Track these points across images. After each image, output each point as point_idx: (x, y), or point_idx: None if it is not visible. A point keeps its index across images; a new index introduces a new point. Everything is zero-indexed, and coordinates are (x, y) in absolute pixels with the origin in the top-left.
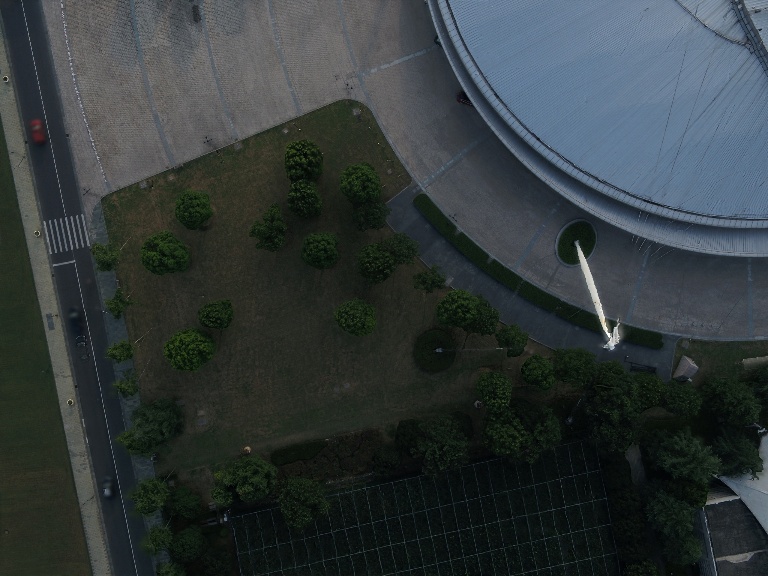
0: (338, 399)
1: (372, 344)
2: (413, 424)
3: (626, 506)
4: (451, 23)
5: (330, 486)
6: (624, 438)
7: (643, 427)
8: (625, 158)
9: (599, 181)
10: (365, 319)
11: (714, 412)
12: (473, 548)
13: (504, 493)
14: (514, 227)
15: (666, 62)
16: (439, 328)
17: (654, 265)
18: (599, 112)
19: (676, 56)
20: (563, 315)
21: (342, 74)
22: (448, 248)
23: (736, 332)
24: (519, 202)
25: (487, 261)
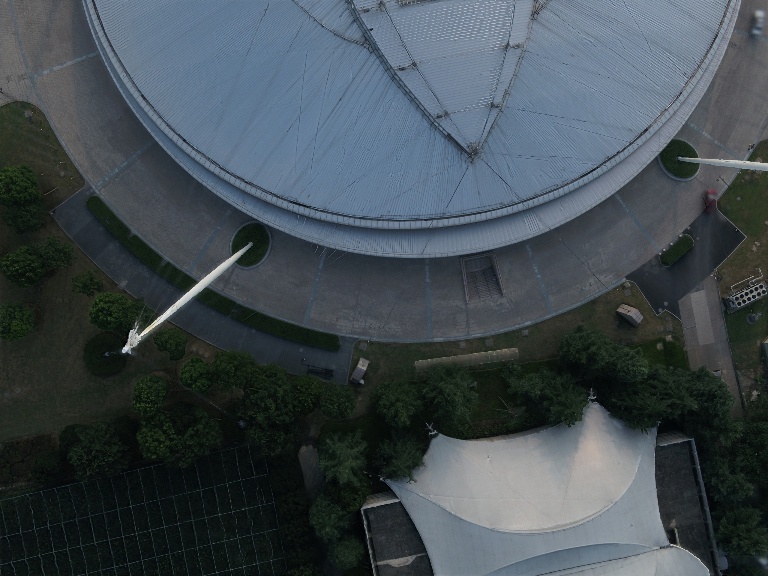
0: (9, 404)
1: (42, 348)
2: (74, 429)
3: (287, 510)
4: (98, 24)
5: (0, 492)
6: (275, 442)
7: (321, 430)
8: (265, 159)
9: (246, 182)
10: (11, 323)
11: (380, 415)
12: (139, 554)
13: (171, 498)
14: (189, 229)
15: (290, 62)
16: (111, 332)
17: (331, 267)
18: (234, 113)
19: (299, 56)
20: (237, 318)
21: (14, 76)
22: (122, 251)
23: (415, 334)
24: (194, 204)
25: (161, 264)
